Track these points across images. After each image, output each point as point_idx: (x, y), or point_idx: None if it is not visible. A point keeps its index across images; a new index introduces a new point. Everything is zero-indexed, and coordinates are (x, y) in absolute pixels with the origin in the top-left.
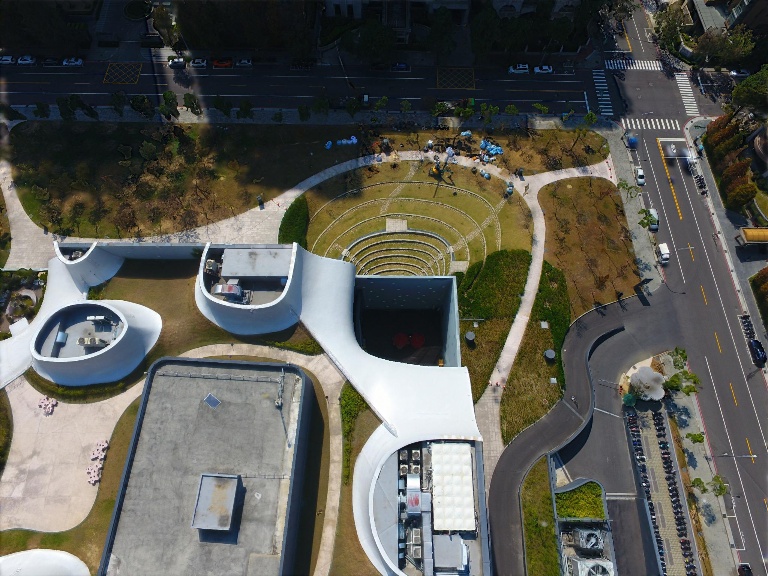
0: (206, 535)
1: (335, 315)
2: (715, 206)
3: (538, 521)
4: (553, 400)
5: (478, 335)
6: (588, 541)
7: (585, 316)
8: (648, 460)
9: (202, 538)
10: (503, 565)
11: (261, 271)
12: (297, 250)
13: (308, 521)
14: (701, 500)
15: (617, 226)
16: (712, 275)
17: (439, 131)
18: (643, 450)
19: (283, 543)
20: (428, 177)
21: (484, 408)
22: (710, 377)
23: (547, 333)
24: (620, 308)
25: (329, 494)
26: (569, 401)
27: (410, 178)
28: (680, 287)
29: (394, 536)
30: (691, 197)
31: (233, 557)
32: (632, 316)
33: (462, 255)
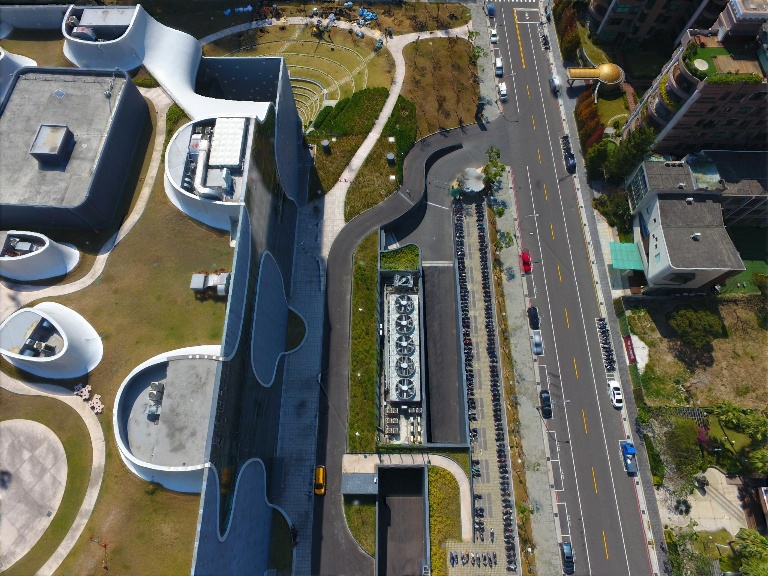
0: (43, 166)
1: (173, 66)
2: (555, 58)
3: (365, 272)
4: (390, 191)
5: (335, 146)
6: (400, 281)
7: (430, 137)
8: (467, 238)
9: (40, 168)
10: (333, 303)
11: (110, 22)
12: (139, 9)
13: (132, 185)
14: (505, 264)
15: (468, 73)
16: (543, 108)
17: (326, 4)
18: (464, 231)
19: (96, 167)
20: (311, 37)
21: (332, 197)
22: (528, 180)
23: (393, 145)
24: (461, 132)
25: (150, 169)
26: (404, 192)
27: (295, 38)
28: (514, 117)
29: (181, 171)
30: (535, 52)
31: (61, 178)
32: (470, 138)
33: (334, 95)
